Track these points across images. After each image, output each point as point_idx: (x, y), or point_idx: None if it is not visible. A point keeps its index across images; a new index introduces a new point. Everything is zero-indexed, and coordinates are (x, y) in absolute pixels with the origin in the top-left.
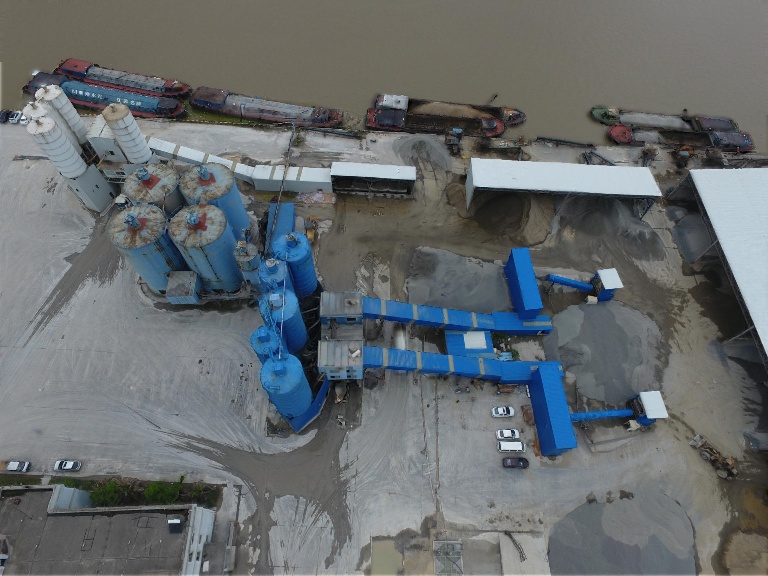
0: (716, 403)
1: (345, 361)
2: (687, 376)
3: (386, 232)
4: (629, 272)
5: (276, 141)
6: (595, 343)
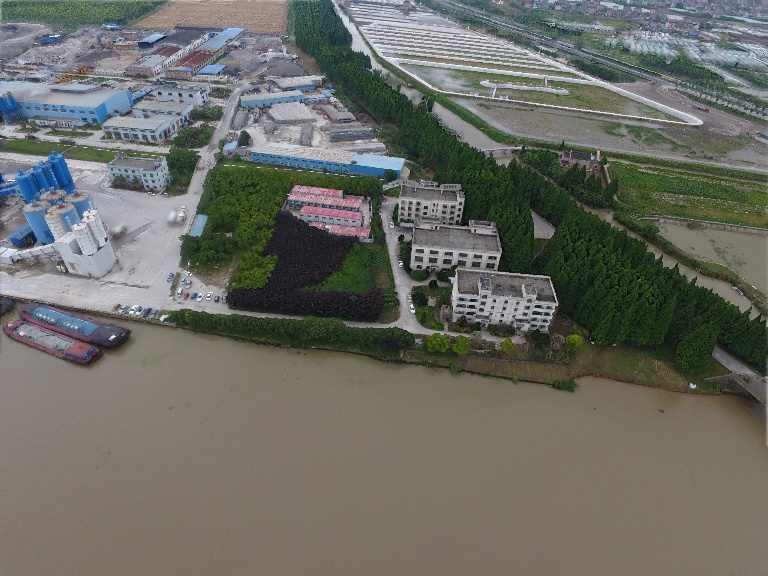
0: None
1: None
2: None
3: None
4: None
5: None
6: None
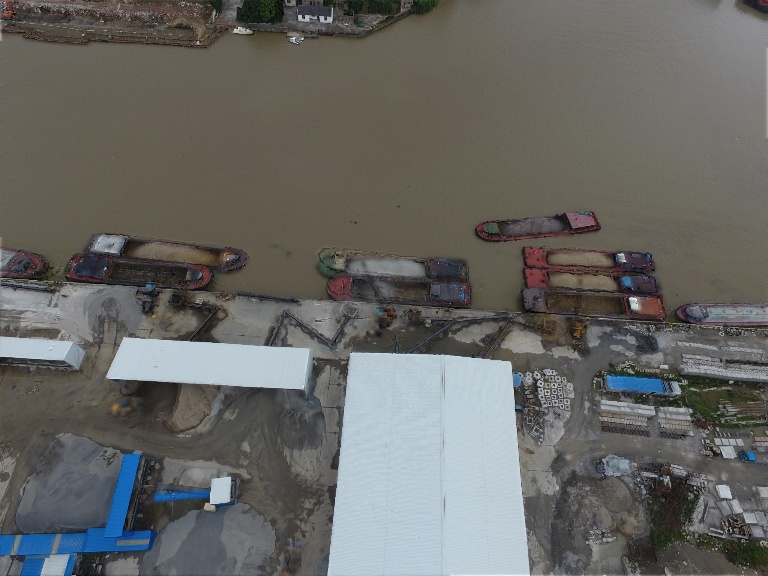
0: None
1: None
2: None
3: (32, 415)
4: (274, 465)
5: None
6: (185, 568)
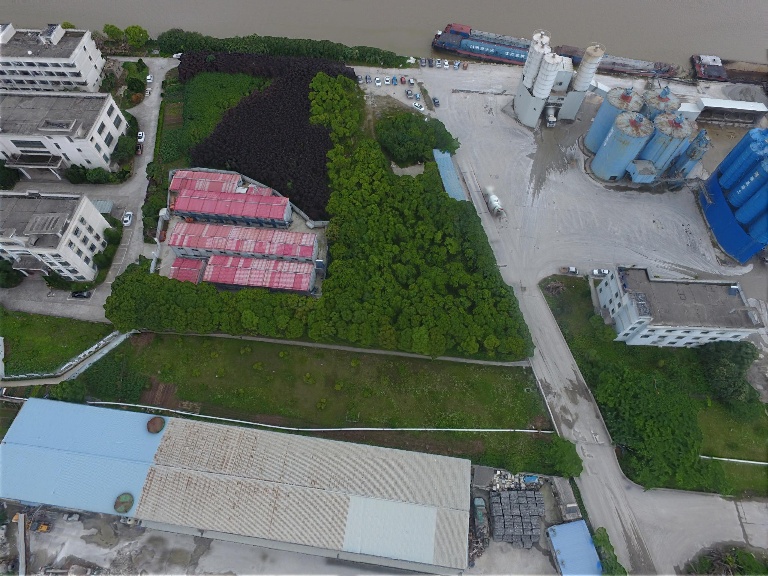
0: None
1: None
2: None
3: None
4: None
5: (633, 85)
6: None
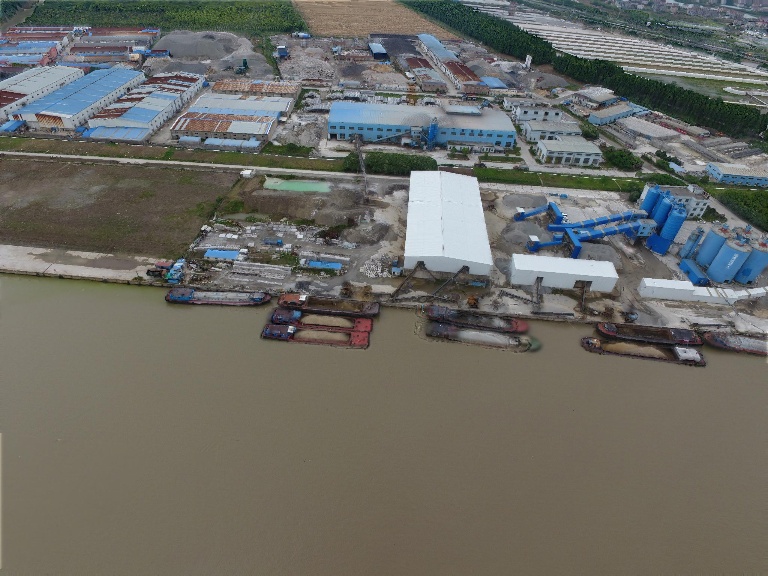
0: (487, 220)
1: (636, 210)
2: (496, 226)
3: None
4: None
5: (745, 325)
6: (537, 230)
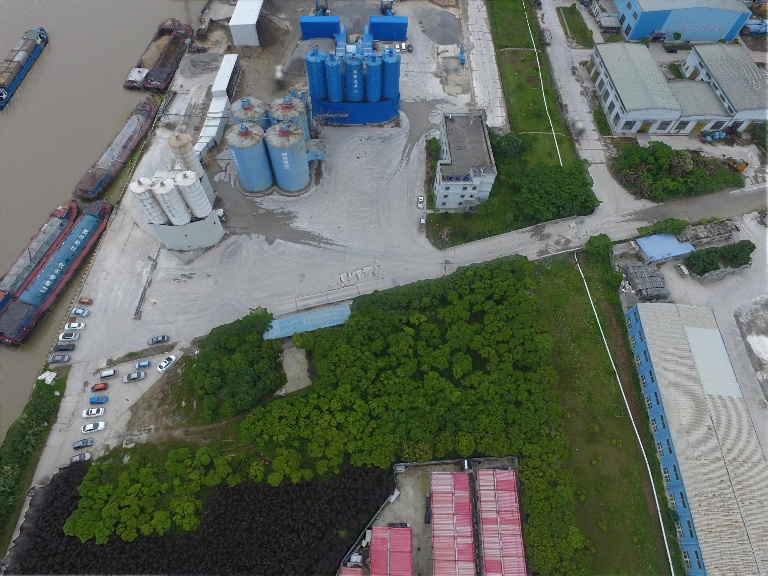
0: None
1: None
2: None
3: (269, 84)
4: (310, 1)
5: (165, 139)
6: (354, 13)
